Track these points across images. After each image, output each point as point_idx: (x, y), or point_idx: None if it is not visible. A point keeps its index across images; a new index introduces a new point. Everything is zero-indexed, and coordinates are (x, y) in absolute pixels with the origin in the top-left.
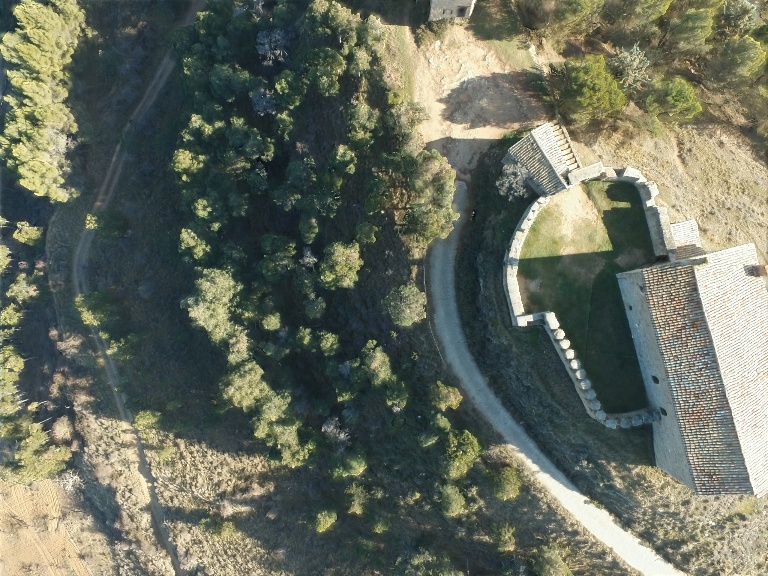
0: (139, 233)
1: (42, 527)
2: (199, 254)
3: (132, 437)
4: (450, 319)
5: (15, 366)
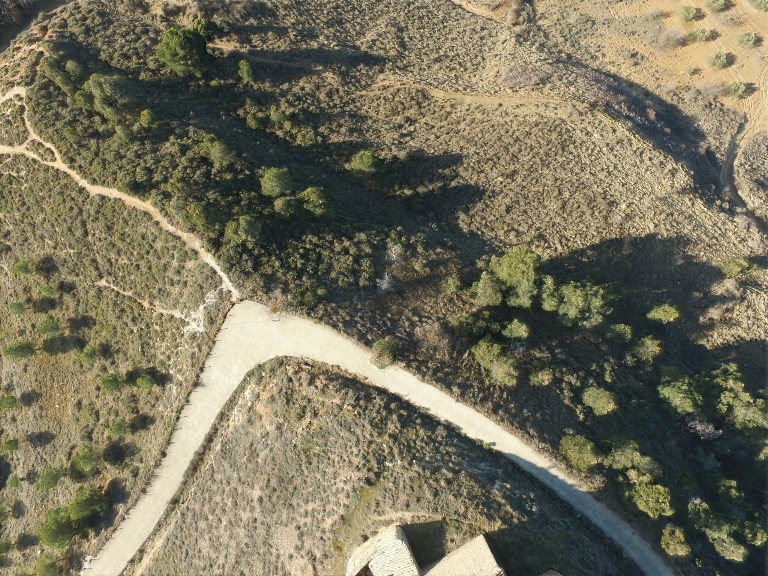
0: None
1: None
2: None
3: None
4: None
5: None
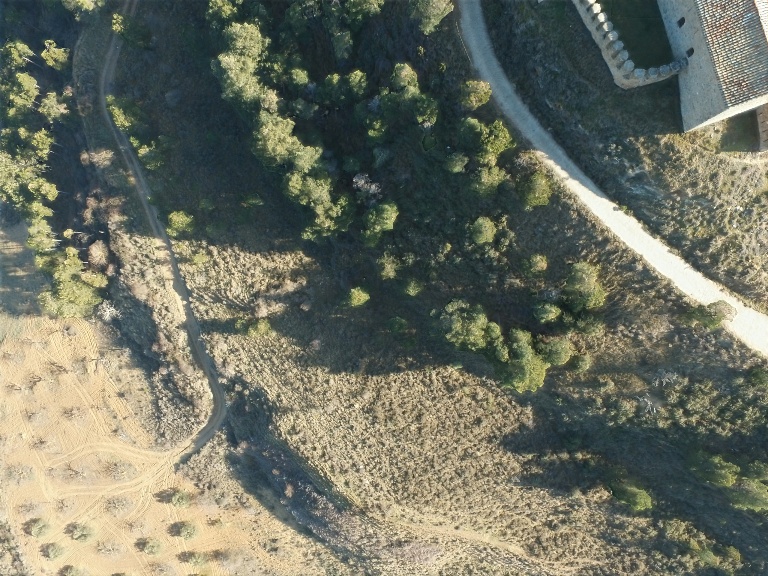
0: (163, 45)
1: (81, 370)
2: (227, 11)
3: (166, 254)
4: (476, 24)
5: (49, 191)
